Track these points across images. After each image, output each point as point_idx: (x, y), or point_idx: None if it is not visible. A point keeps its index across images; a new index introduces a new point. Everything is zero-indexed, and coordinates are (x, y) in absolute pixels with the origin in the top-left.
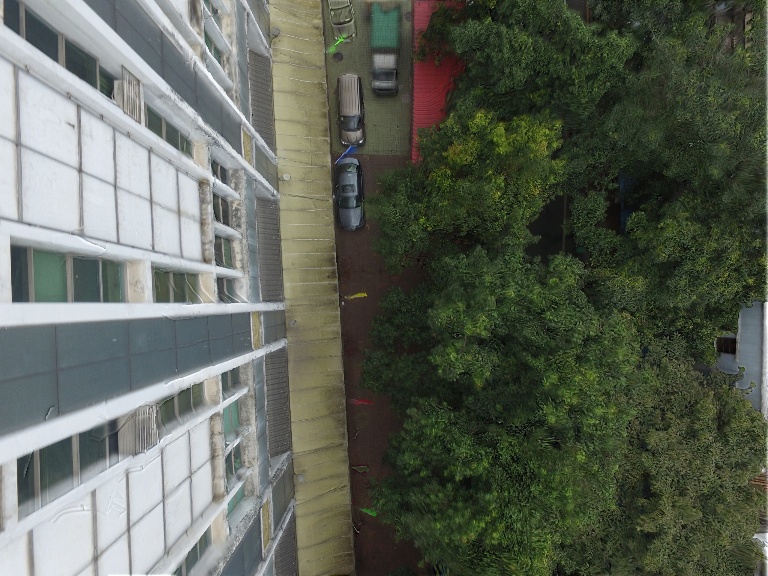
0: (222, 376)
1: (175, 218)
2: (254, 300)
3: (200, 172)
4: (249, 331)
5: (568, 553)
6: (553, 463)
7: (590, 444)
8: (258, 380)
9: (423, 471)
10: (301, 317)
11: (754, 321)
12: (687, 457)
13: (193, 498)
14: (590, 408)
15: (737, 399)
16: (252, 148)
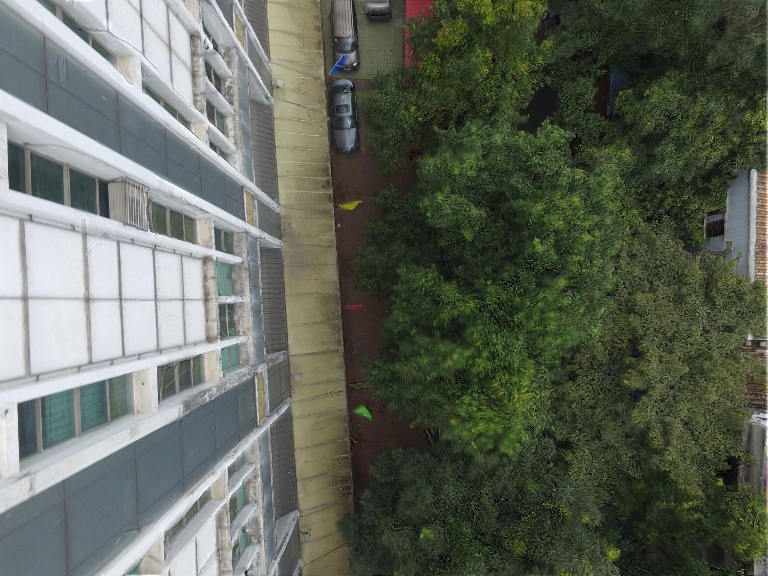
0: (216, 237)
1: (166, 50)
2: (247, 178)
3: (191, 19)
4: (242, 204)
5: (559, 425)
6: (540, 313)
7: (577, 294)
8: (252, 258)
9: (413, 330)
10: (296, 224)
11: (741, 196)
12: (674, 319)
13: (186, 323)
14: (575, 245)
15: None
16: (244, 36)
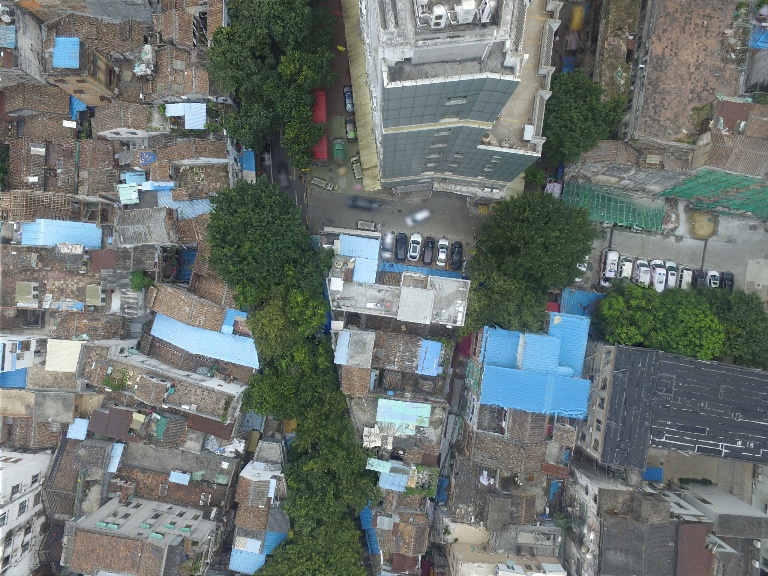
0: None
1: None
2: None
3: None
4: None
5: None
6: None
7: None
8: None
9: None
10: None
11: None
12: None
13: None
14: None
15: (230, 5)
16: None
